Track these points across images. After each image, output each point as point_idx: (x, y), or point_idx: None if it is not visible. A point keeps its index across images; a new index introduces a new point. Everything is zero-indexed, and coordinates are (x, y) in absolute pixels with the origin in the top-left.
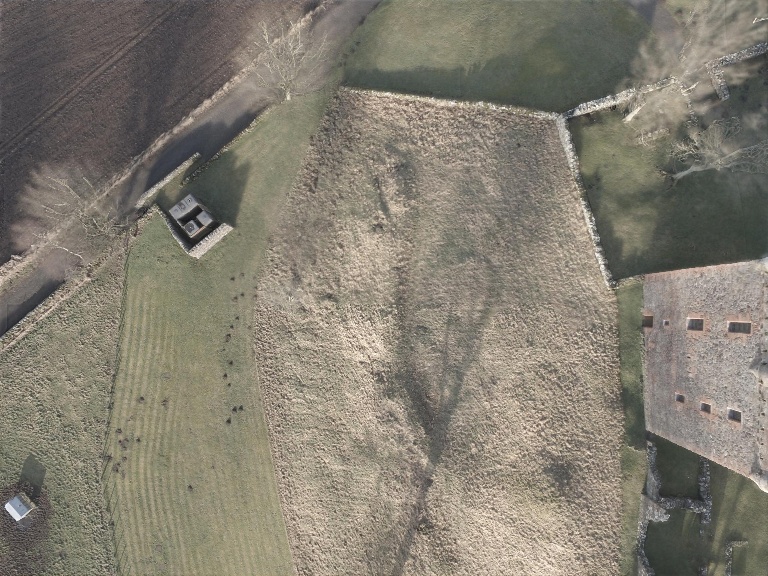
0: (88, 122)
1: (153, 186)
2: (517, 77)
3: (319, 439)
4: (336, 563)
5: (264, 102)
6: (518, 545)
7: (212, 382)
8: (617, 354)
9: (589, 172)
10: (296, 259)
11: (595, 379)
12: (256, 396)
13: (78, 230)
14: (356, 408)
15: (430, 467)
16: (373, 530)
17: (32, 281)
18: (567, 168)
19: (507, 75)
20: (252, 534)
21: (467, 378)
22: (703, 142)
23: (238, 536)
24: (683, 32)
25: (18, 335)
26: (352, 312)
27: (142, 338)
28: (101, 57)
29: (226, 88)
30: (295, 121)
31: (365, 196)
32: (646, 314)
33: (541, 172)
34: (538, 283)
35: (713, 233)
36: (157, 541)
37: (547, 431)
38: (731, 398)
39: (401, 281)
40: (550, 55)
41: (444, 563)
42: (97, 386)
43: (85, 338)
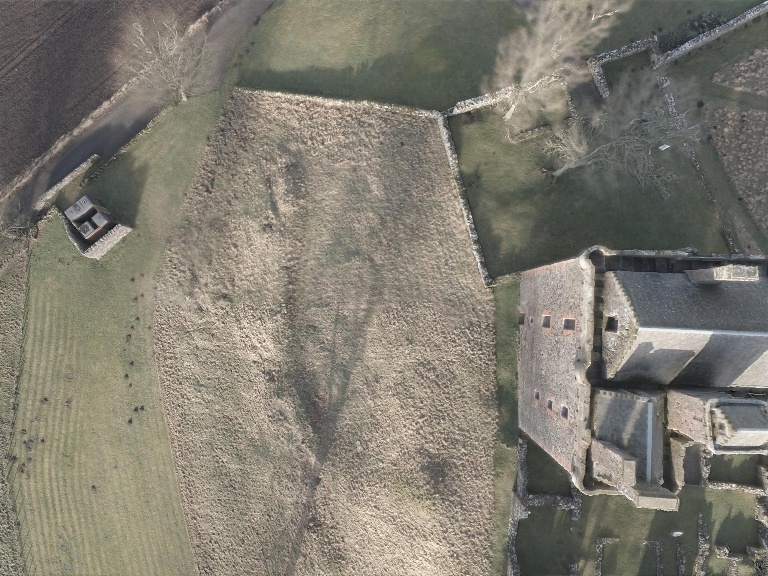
0: None
1: (51, 188)
2: (402, 76)
3: (217, 438)
4: (234, 562)
5: (161, 103)
6: (398, 543)
7: (114, 382)
8: (493, 352)
9: (469, 170)
10: (194, 259)
11: (471, 377)
12: (157, 396)
13: None
14: (251, 407)
15: (318, 466)
16: (268, 529)
17: None
18: (448, 166)
19: (393, 74)
20: (154, 533)
21: (353, 377)
22: (569, 139)
23: (141, 535)
24: (567, 29)
25: None
26: (245, 312)
27: (45, 339)
28: (3, 60)
29: (124, 89)
30: (192, 122)
31: (257, 196)
32: (521, 312)
33: (423, 170)
34: (418, 281)
35: (591, 230)
36: (62, 541)
37: (425, 429)
38: (563, 395)
39: (291, 280)
40: (434, 53)
41: (332, 561)
42: (2, 387)
43: None
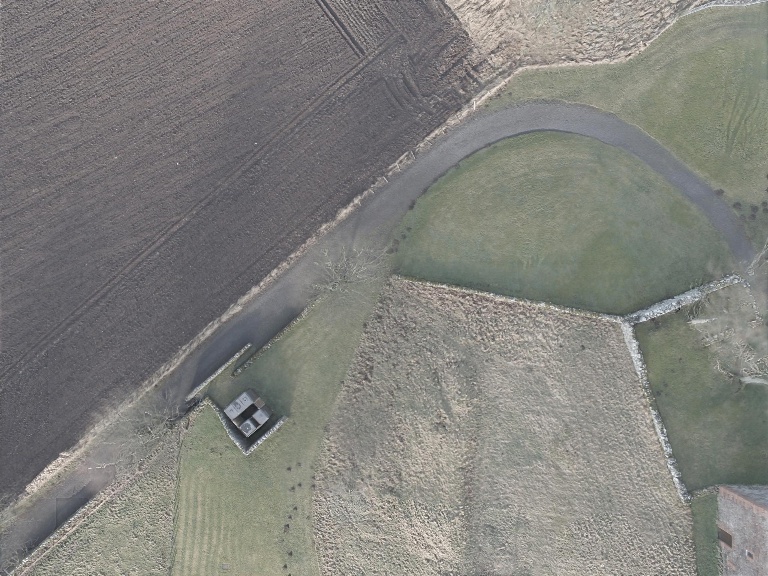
0: (132, 311)
1: (205, 381)
2: (577, 274)
3: None
4: None
5: (315, 290)
6: None
7: (272, 573)
8: (694, 569)
9: (657, 378)
10: (354, 449)
11: None
12: None
13: (127, 422)
14: None
15: None
16: None
17: (81, 474)
18: (634, 373)
19: (567, 271)
20: None
21: None
22: None
23: None
24: (743, 225)
25: (69, 530)
26: (416, 510)
27: (197, 530)
28: (143, 243)
29: (275, 275)
30: (347, 308)
31: (425, 391)
32: (722, 529)
33: (608, 377)
34: (610, 493)
35: None
36: None
37: None
38: None
39: (466, 481)
40: (610, 252)
41: None
42: None
43: (138, 531)
